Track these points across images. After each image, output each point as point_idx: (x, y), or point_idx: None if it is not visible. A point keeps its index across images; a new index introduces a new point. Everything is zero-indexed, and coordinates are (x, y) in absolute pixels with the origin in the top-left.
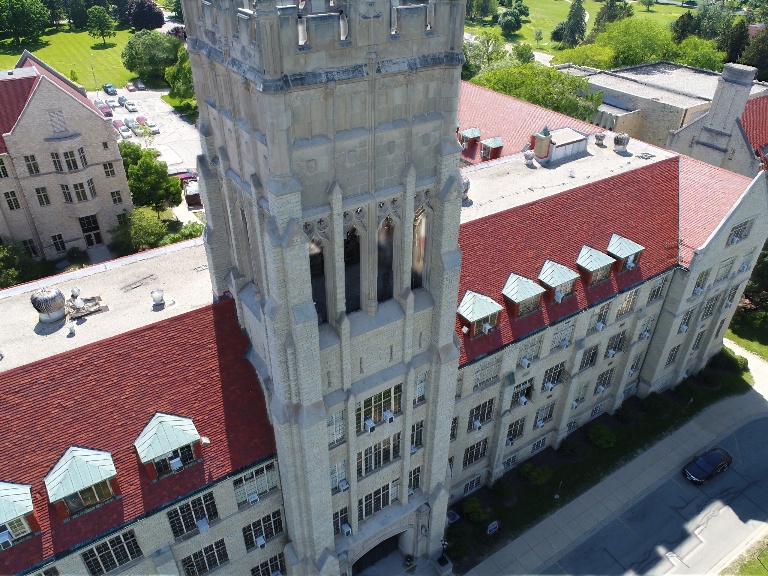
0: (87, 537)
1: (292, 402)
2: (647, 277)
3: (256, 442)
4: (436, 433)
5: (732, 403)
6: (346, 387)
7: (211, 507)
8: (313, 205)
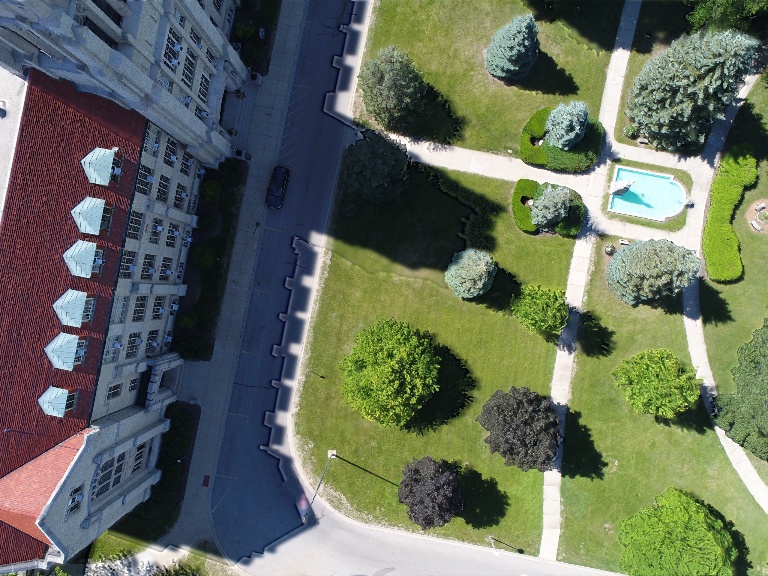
0: (123, 230)
1: (142, 97)
2: None
3: (134, 125)
4: (203, 27)
5: None
6: (153, 61)
7: (146, 169)
8: (67, 5)
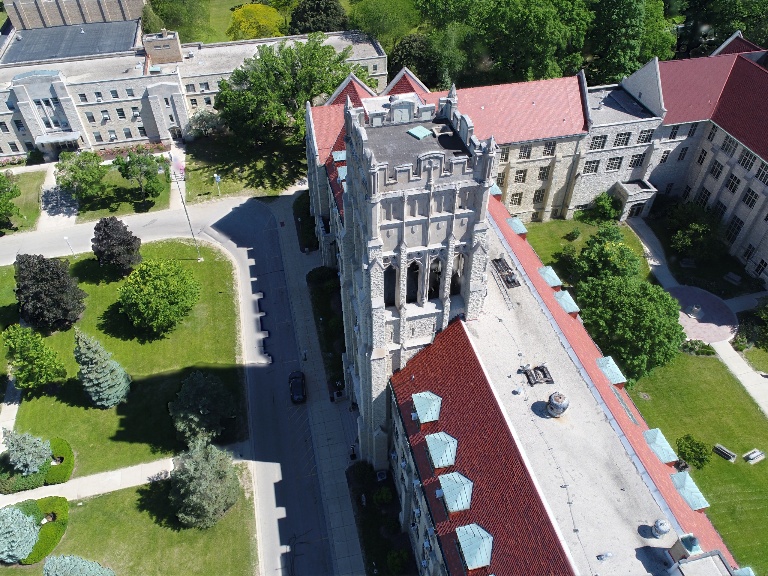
0: None
1: None
2: None
3: None
4: None
5: None
6: None
7: None
8: None
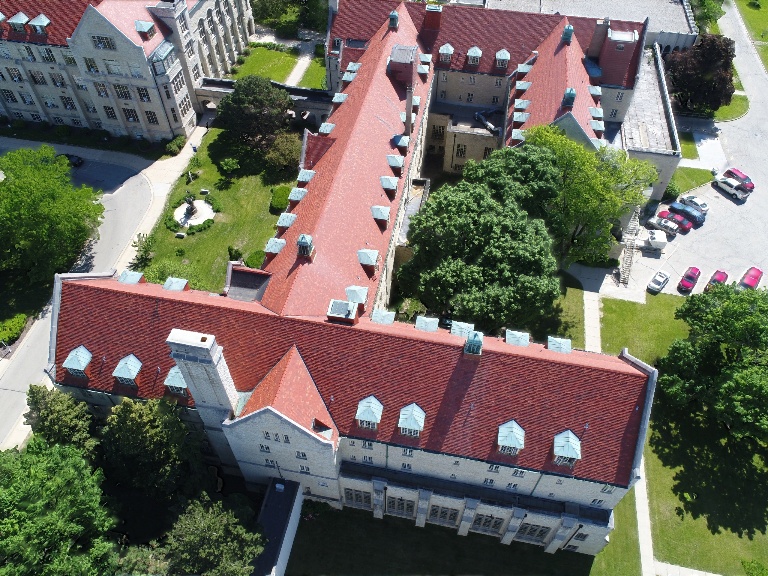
0: None
1: None
2: (50, 43)
3: None
4: None
5: (134, 158)
6: None
7: None
8: None
